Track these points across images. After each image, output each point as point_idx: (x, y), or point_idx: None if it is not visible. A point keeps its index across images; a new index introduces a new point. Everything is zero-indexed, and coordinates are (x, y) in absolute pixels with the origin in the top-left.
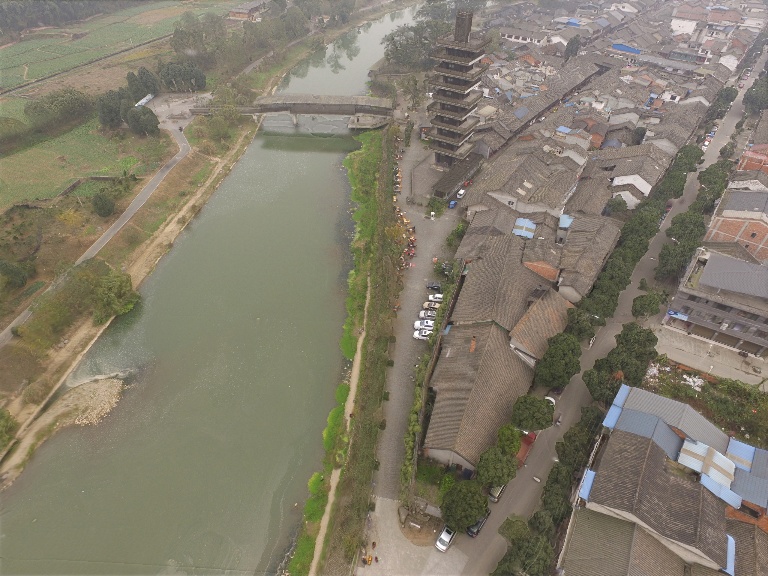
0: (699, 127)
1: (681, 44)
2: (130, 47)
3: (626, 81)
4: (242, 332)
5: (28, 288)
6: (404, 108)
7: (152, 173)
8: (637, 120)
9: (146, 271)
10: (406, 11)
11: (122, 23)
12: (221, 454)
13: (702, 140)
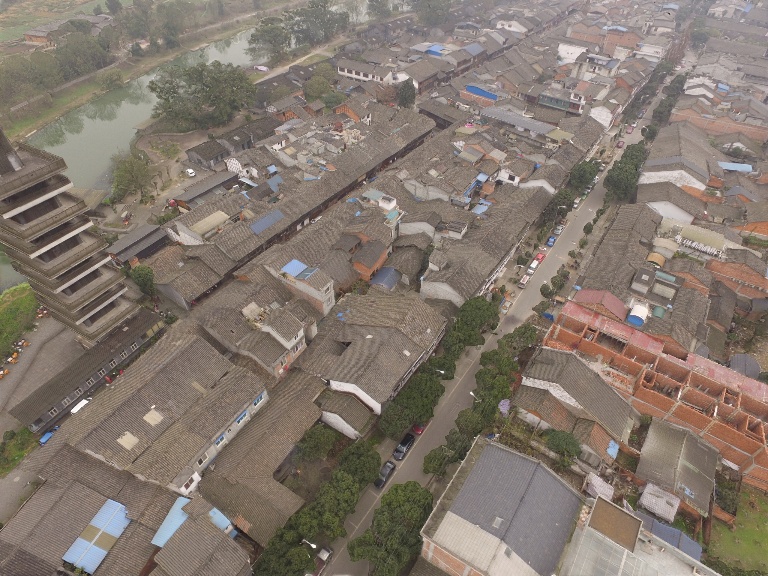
0: (539, 226)
1: (553, 84)
2: None
3: (460, 148)
4: None
5: None
6: (138, 198)
7: None
8: (433, 232)
9: None
10: None
11: None
12: None
13: (523, 264)
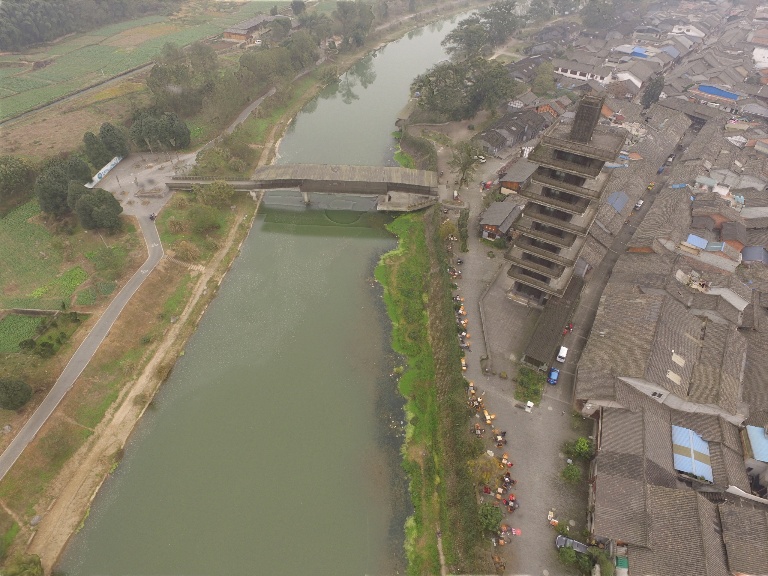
0: None
1: None
2: (101, 81)
3: (735, 142)
4: None
5: None
6: (449, 180)
7: (104, 303)
8: None
9: (73, 523)
10: (425, 27)
11: (97, 46)
12: None
13: None
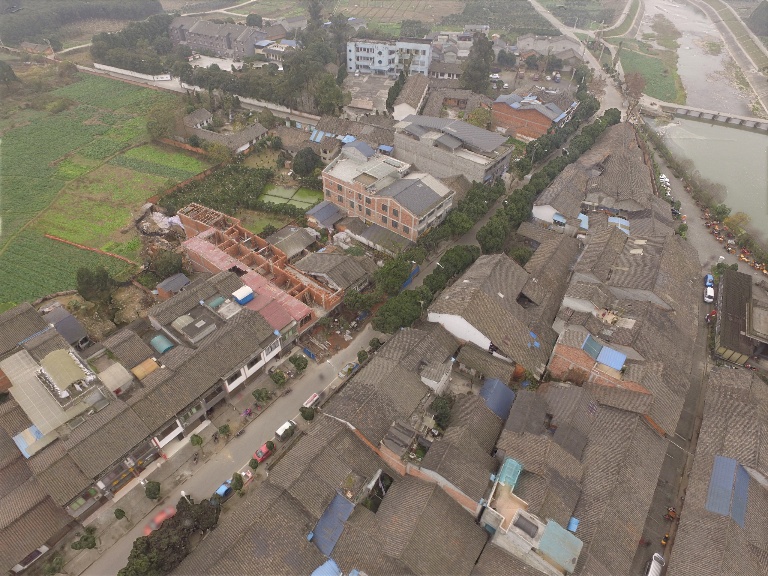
0: None
1: None
2: None
3: None
4: None
5: None
6: None
7: None
8: None
9: None
10: None
11: None
12: None
13: None
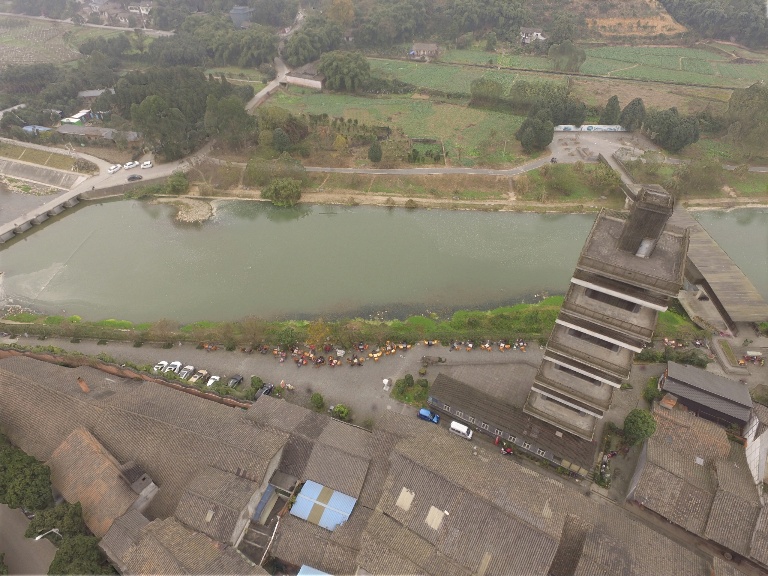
0: None
1: None
2: None
3: None
4: (238, 262)
5: (294, 159)
6: None
7: (455, 166)
8: None
9: (320, 201)
10: None
11: None
12: (124, 271)
13: None
